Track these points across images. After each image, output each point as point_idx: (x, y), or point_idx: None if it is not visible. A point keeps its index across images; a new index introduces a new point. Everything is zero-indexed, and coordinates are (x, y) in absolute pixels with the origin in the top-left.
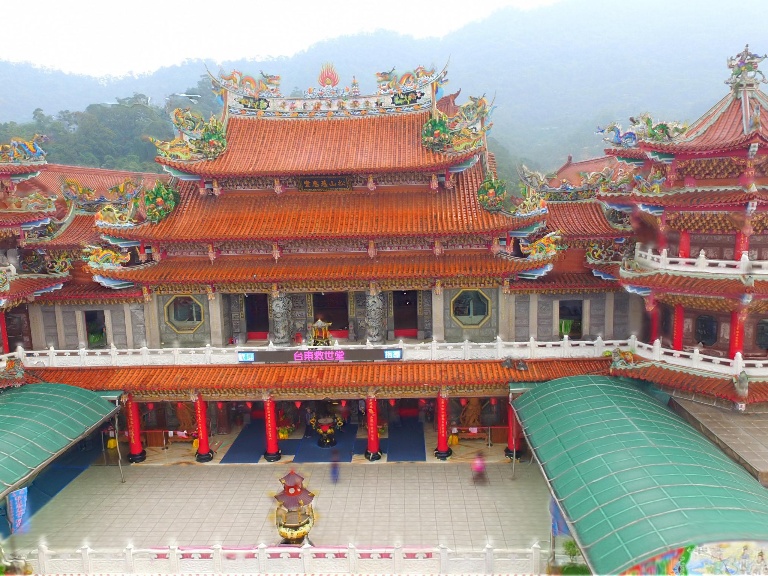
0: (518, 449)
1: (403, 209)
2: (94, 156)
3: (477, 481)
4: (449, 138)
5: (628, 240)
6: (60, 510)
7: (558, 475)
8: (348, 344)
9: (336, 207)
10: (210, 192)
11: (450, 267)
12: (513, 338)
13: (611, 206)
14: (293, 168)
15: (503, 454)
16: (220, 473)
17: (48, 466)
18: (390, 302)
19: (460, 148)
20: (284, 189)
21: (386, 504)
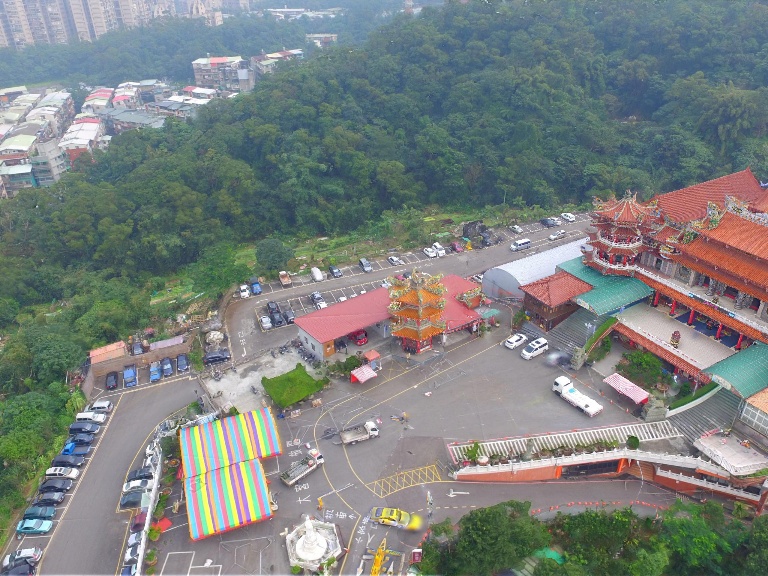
0: None
1: (764, 272)
2: (756, 41)
3: None
4: None
5: None
6: (631, 311)
7: None
8: (731, 303)
9: (743, 261)
10: None
11: (767, 298)
12: None
13: None
14: (732, 244)
15: None
16: (672, 321)
17: None
18: None
19: None
20: None
21: (705, 350)
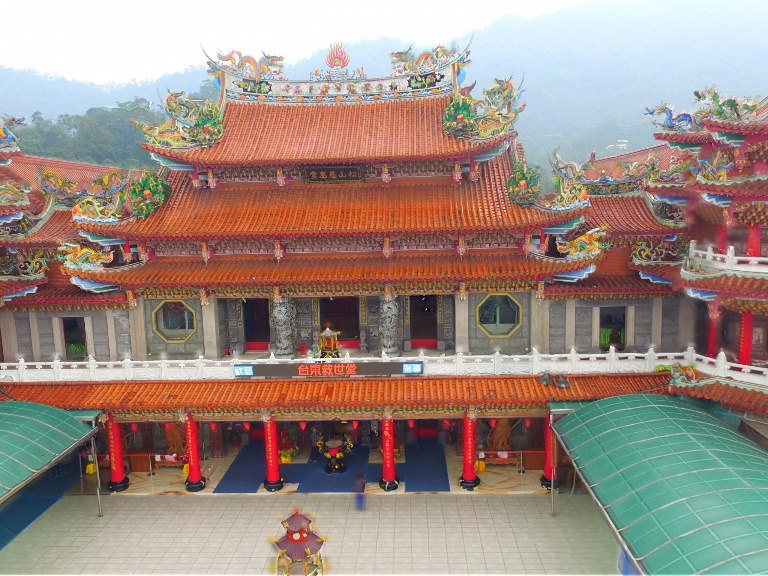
0: (556, 478)
1: (422, 203)
2: (93, 160)
3: (511, 517)
4: (473, 124)
5: (680, 238)
6: (24, 551)
7: (629, 524)
8: (359, 356)
9: (346, 201)
10: (205, 184)
11: (476, 268)
12: (547, 349)
13: (662, 199)
14: (298, 156)
15: (538, 483)
16: (213, 505)
17: (14, 497)
18: (406, 308)
19: (487, 134)
20: (288, 181)
21: (407, 546)
